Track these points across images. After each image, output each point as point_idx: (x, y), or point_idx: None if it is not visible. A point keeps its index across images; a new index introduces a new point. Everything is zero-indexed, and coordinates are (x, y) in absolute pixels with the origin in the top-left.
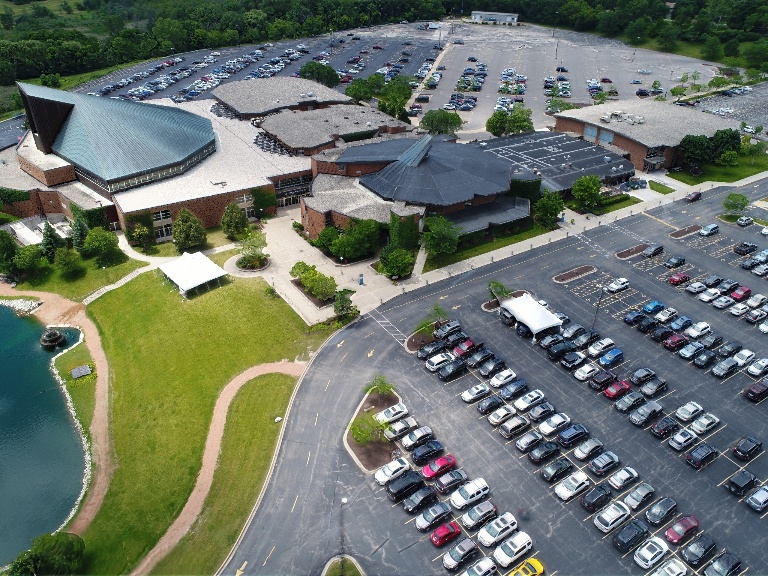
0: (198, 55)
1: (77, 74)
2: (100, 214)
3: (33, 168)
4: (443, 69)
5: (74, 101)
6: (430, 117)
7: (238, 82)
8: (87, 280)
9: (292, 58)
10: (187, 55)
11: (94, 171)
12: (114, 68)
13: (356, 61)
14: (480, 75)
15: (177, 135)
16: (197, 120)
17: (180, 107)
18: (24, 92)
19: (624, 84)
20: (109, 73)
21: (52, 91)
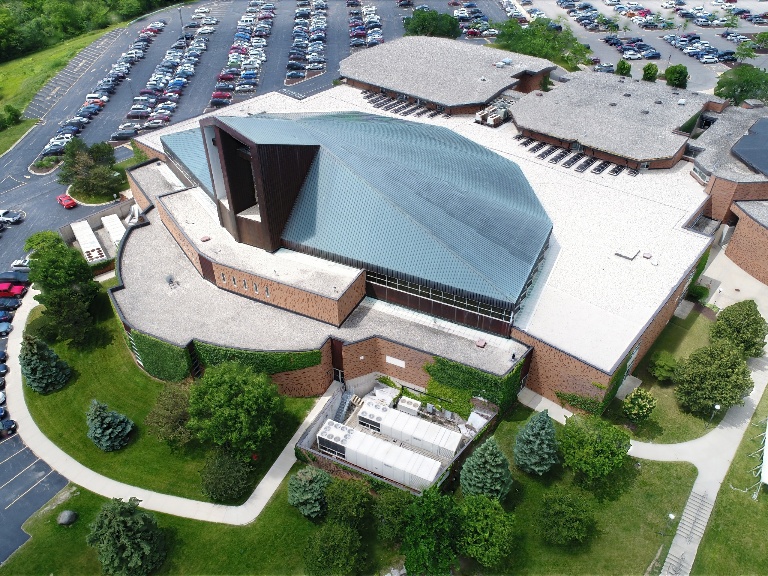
0: (176, 14)
1: (4, 62)
2: (518, 375)
3: (287, 292)
4: (530, 4)
5: (313, 138)
6: (752, 79)
7: (366, 53)
8: (612, 541)
9: (321, 6)
10: (160, 16)
11: (460, 285)
12: (64, 47)
13: (412, 3)
14: (591, 7)
15: (487, 172)
16: (445, 133)
17: (318, 106)
18: (244, 138)
19: (754, 3)
20: (73, 56)
21: (272, 124)
